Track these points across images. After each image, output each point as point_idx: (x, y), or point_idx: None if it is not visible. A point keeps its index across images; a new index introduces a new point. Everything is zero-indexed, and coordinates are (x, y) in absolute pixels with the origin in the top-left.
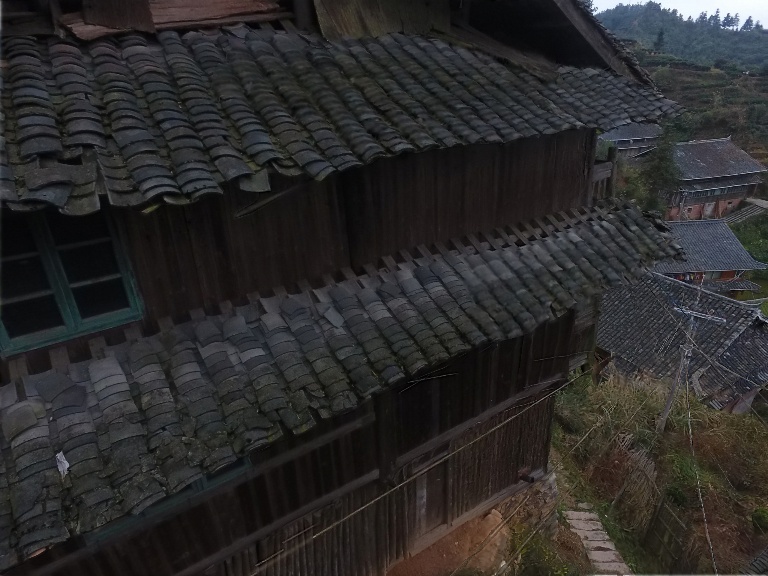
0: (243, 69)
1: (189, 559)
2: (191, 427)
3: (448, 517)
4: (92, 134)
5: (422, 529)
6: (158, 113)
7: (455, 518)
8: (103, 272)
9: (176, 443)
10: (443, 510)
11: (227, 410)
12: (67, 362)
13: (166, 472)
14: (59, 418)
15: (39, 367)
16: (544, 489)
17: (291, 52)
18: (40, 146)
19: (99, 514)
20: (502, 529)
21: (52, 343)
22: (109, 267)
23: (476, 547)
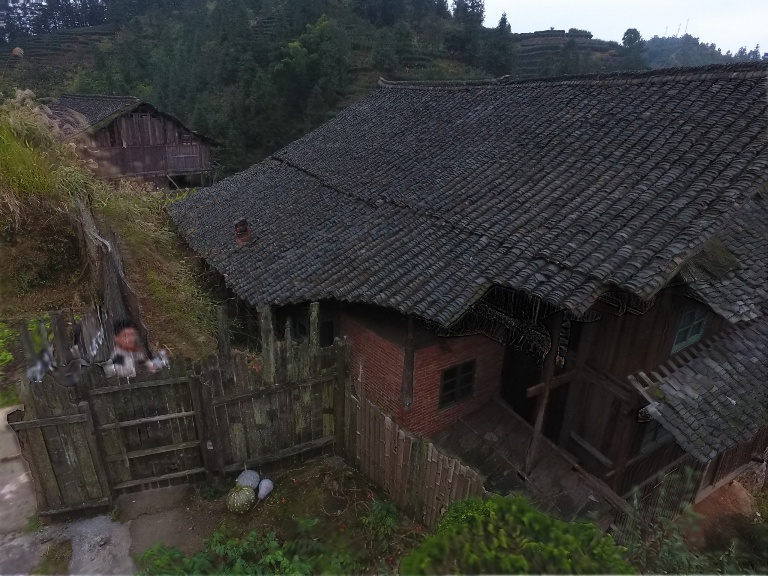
0: (761, 224)
1: (650, 473)
2: (762, 390)
3: (714, 480)
4: (765, 266)
5: (700, 486)
6: (767, 254)
7: (717, 482)
8: (701, 317)
9: (763, 396)
10: (712, 475)
11: (766, 384)
12: (692, 358)
13: (767, 408)
14: (715, 382)
15: (685, 360)
16: (758, 471)
17: (760, 209)
18: (765, 274)
19: (762, 421)
20: (747, 493)
21: (681, 349)
22: (704, 315)
23: (735, 502)
